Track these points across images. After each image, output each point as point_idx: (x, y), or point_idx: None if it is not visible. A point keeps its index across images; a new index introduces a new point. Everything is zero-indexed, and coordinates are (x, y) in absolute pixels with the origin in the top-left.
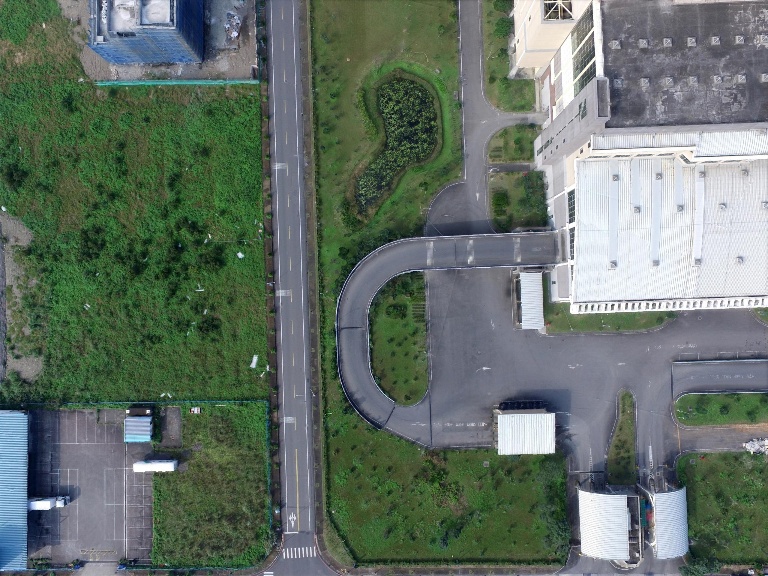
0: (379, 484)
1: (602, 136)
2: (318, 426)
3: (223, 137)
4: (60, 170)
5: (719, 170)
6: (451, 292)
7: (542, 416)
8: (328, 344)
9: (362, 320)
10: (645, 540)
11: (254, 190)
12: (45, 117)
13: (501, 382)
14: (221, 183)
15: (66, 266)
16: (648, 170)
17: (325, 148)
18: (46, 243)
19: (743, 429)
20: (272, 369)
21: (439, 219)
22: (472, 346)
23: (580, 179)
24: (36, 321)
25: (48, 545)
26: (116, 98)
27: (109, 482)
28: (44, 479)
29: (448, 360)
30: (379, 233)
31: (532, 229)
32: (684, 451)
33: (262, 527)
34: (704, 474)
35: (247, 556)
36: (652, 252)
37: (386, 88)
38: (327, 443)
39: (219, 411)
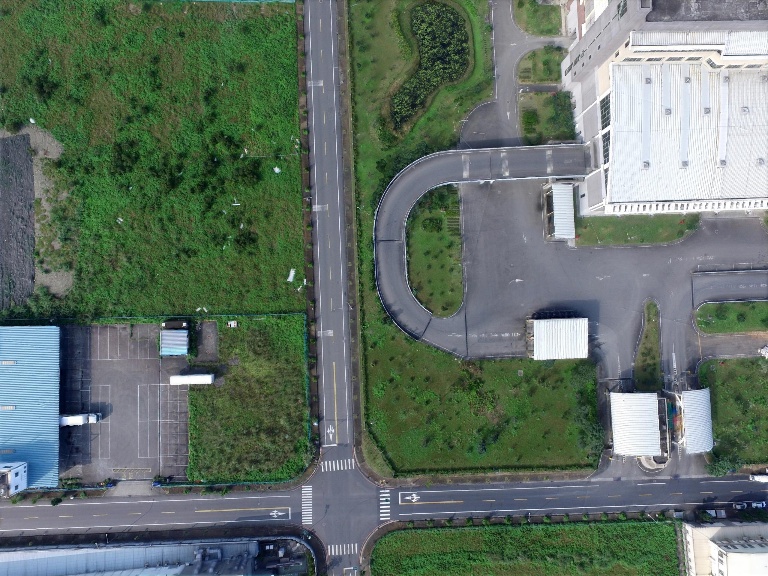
0: (417, 394)
1: (641, 32)
2: (356, 339)
3: (259, 54)
4: (92, 83)
5: (741, 76)
6: (484, 207)
7: (575, 321)
8: (365, 257)
9: (399, 233)
10: (672, 441)
11: (290, 106)
12: (76, 30)
13: (533, 293)
14: (257, 98)
15: (98, 179)
16: (677, 74)
17: (360, 67)
18: (77, 156)
19: (758, 336)
20: (309, 282)
21: (472, 136)
22: (505, 259)
23: (615, 82)
24: (67, 234)
25: (78, 464)
26: (150, 13)
27: (143, 398)
28: (74, 396)
29: (482, 272)
30: (416, 146)
31: (563, 142)
32: (705, 357)
33: (300, 440)
34: (724, 379)
35: (285, 470)
36: (681, 153)
37: (419, 10)
38: (365, 355)
39: (256, 325)
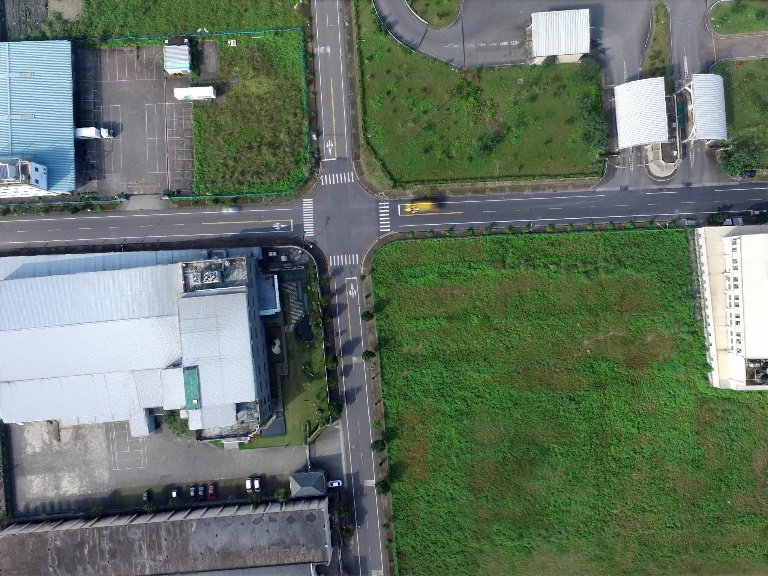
0: (414, 105)
1: None
2: (352, 54)
3: None
4: None
5: None
6: None
7: (576, 12)
8: None
9: None
10: (683, 140)
11: None
12: None
13: None
14: None
15: None
16: None
17: None
18: None
19: None
20: None
21: None
22: None
23: None
24: None
25: (94, 179)
26: None
27: (150, 117)
28: (88, 116)
29: None
30: None
31: None
32: (720, 60)
33: (300, 154)
34: None
35: (286, 182)
36: None
37: None
38: (361, 69)
39: (255, 42)
